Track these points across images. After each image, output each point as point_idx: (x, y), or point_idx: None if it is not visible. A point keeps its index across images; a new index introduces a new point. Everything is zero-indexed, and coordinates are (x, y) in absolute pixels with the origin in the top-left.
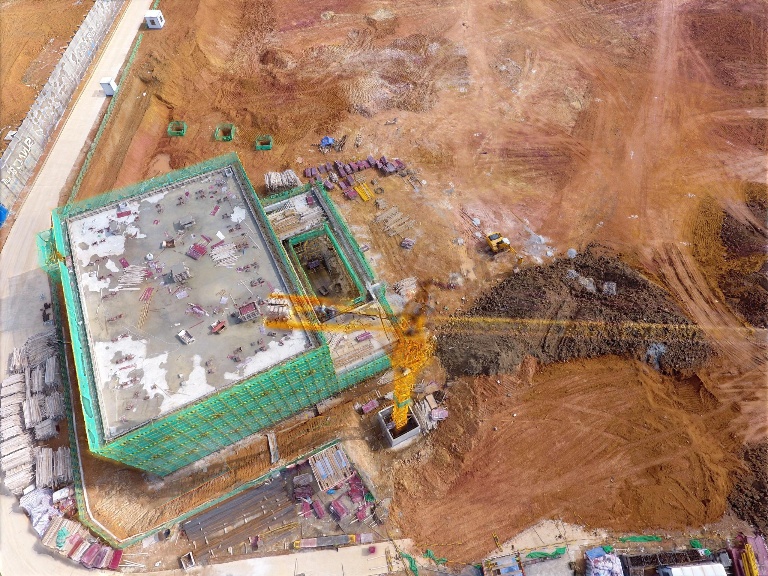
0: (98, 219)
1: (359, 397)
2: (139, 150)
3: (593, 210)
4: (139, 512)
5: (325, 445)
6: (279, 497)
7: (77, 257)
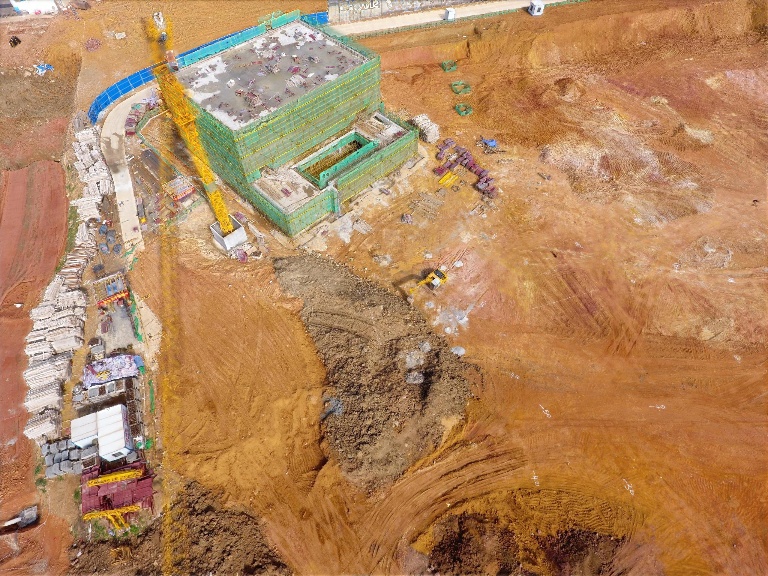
0: (305, 30)
1: None
2: (415, 55)
3: (532, 366)
4: (160, 138)
5: (203, 195)
6: None
7: (275, 32)
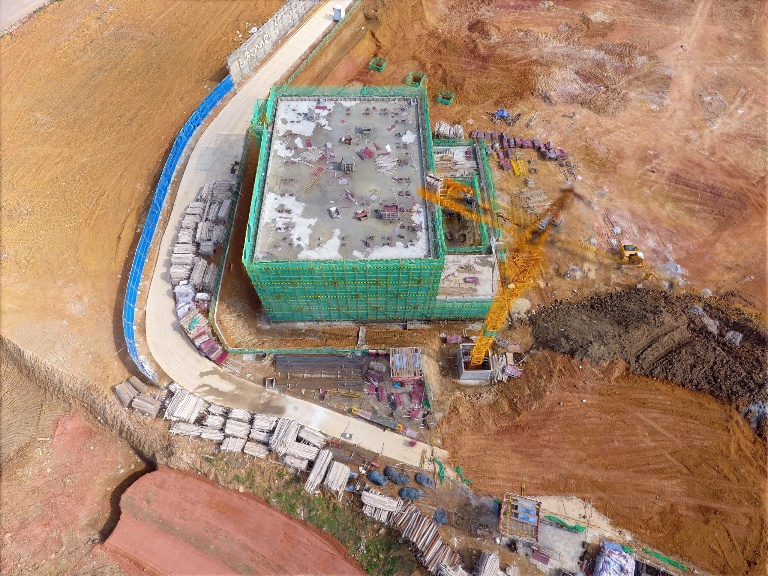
0: (301, 105)
1: (446, 330)
2: (342, 72)
3: (749, 262)
4: (247, 336)
5: None
6: (354, 371)
7: (277, 127)
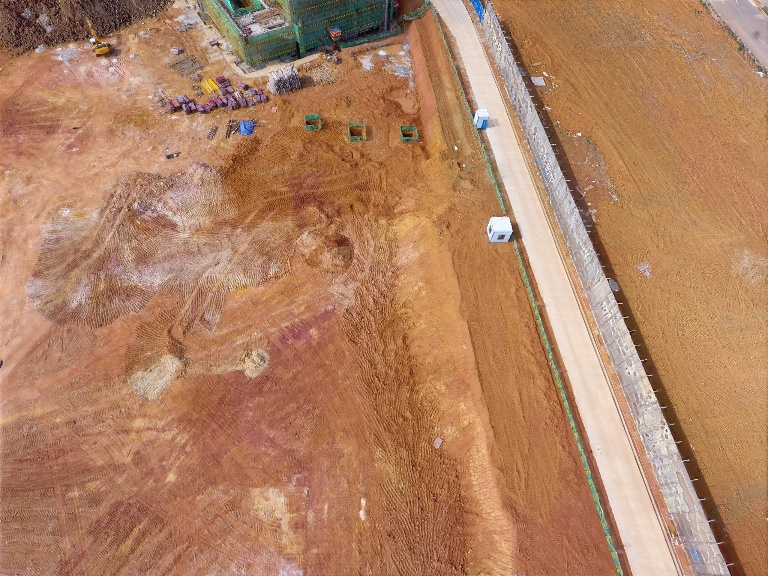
0: None
1: None
2: (429, 101)
3: None
4: None
5: None
6: None
7: None
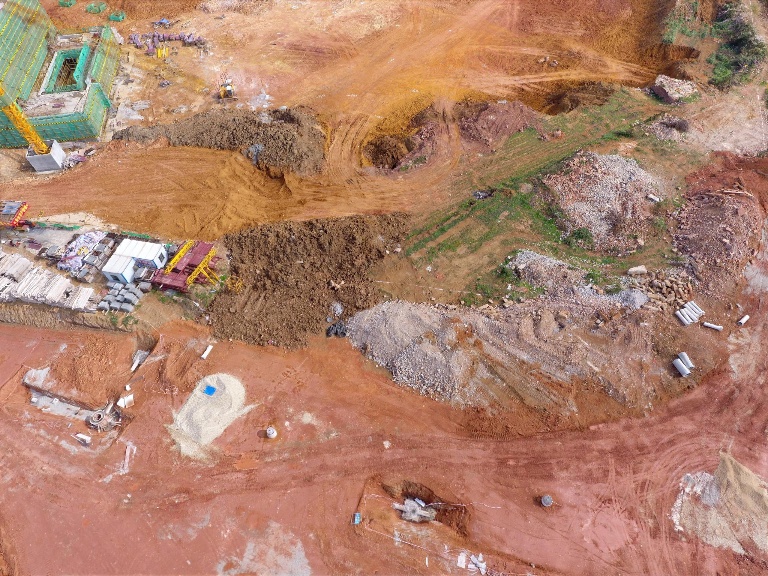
0: None
1: None
2: None
3: (324, 87)
4: None
5: None
6: None
7: None
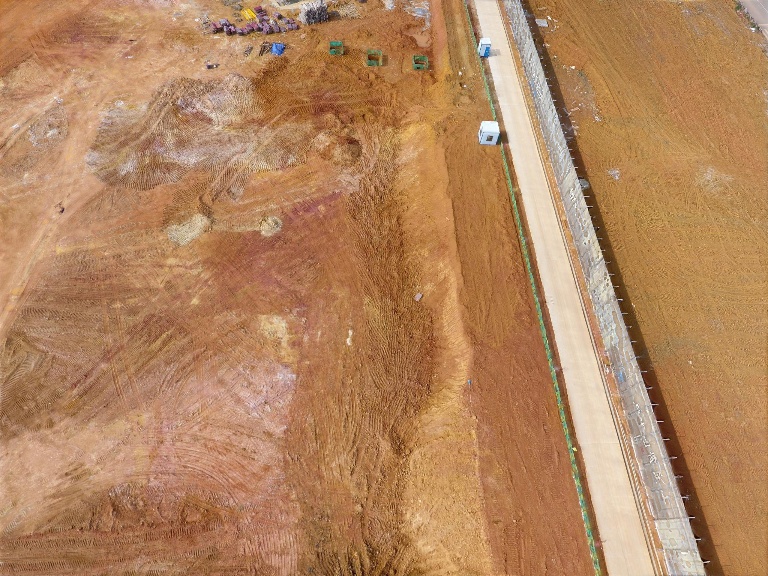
0: None
1: None
2: (441, 37)
3: None
4: None
5: None
6: None
7: None
